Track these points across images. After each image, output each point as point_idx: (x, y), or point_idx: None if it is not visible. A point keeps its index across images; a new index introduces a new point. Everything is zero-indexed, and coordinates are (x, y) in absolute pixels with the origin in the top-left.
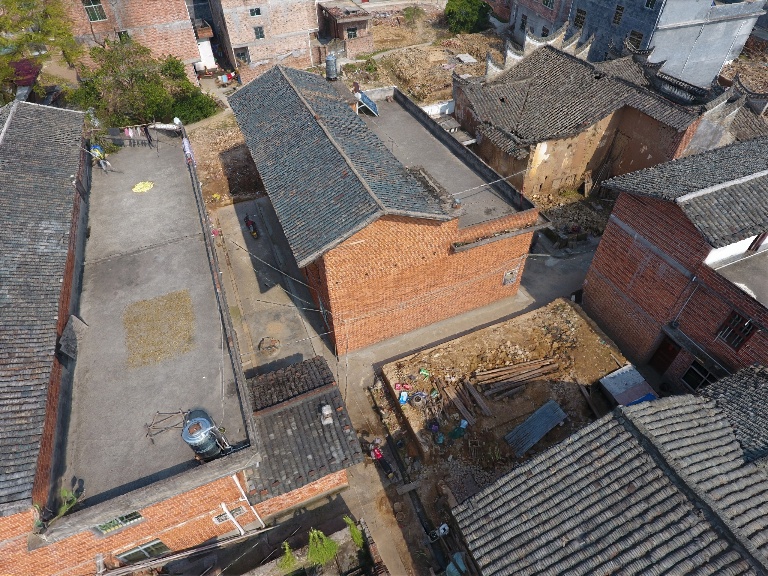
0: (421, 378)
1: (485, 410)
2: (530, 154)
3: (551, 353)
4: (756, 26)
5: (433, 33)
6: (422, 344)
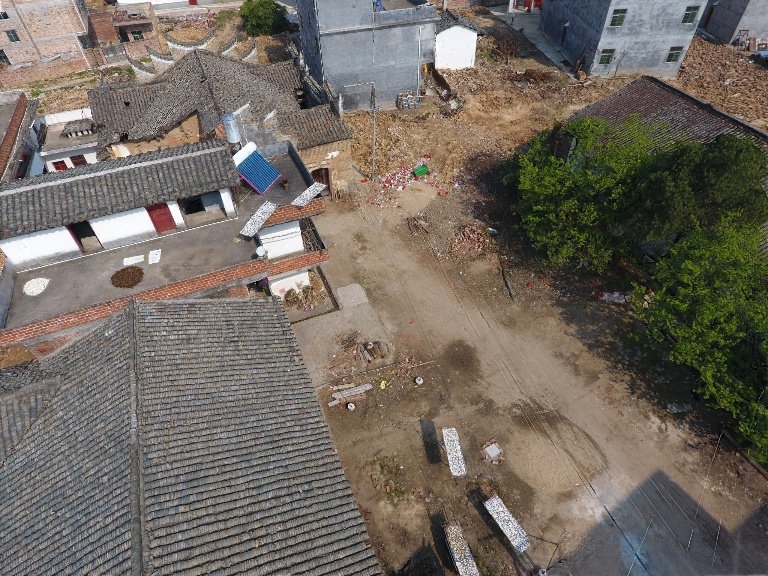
0: None
1: None
2: (111, 156)
3: None
4: (538, 29)
5: None
6: None
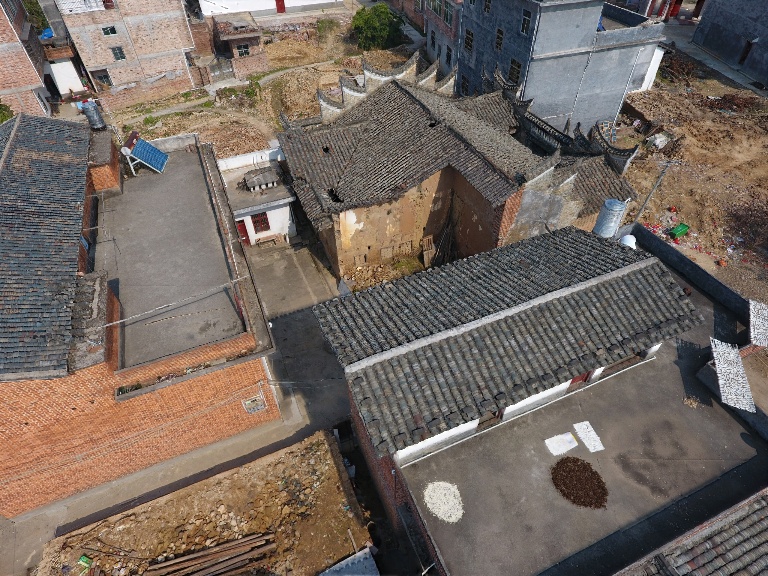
0: (79, 570)
1: None
2: (334, 224)
3: (277, 523)
4: (692, 43)
5: (341, 49)
6: (136, 494)
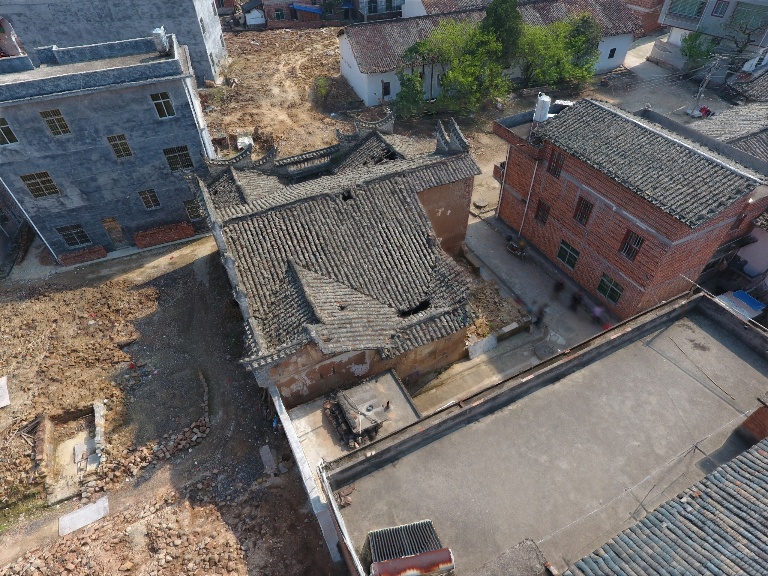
0: None
1: None
2: None
3: None
4: None
5: None
6: None
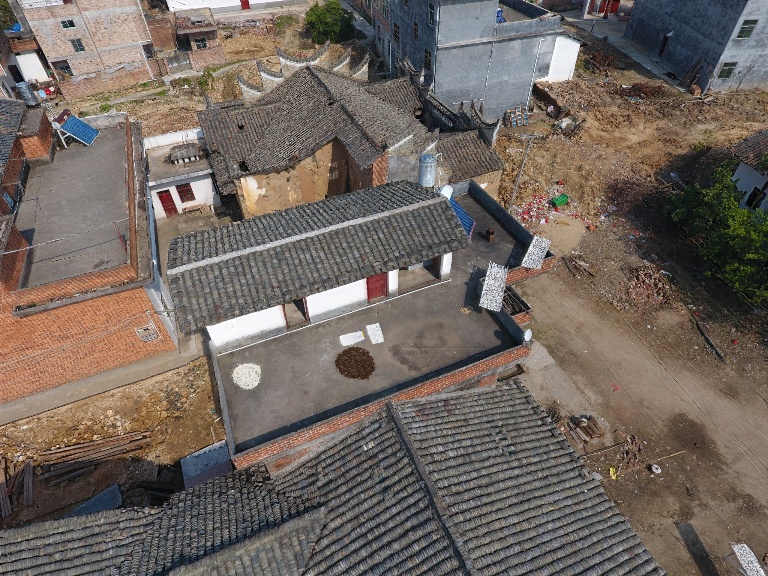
0: None
1: (25, 499)
2: (238, 189)
3: (155, 424)
4: (623, 37)
5: (296, 43)
6: (46, 408)
